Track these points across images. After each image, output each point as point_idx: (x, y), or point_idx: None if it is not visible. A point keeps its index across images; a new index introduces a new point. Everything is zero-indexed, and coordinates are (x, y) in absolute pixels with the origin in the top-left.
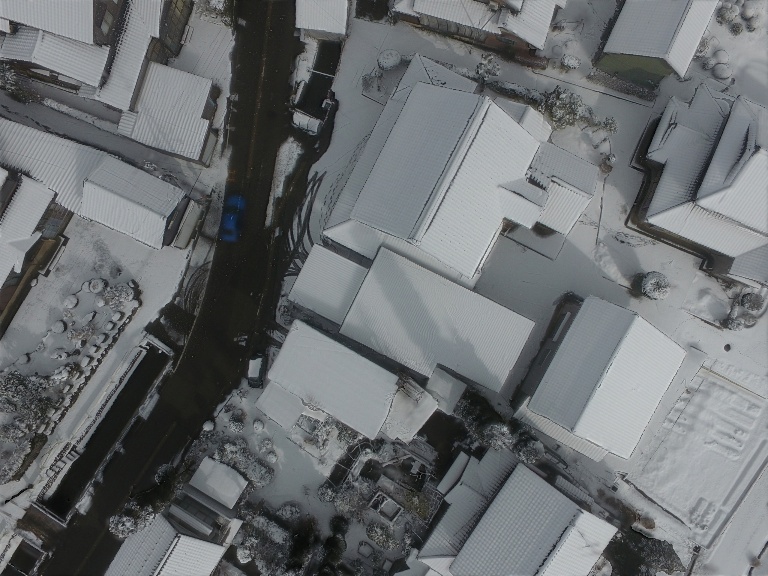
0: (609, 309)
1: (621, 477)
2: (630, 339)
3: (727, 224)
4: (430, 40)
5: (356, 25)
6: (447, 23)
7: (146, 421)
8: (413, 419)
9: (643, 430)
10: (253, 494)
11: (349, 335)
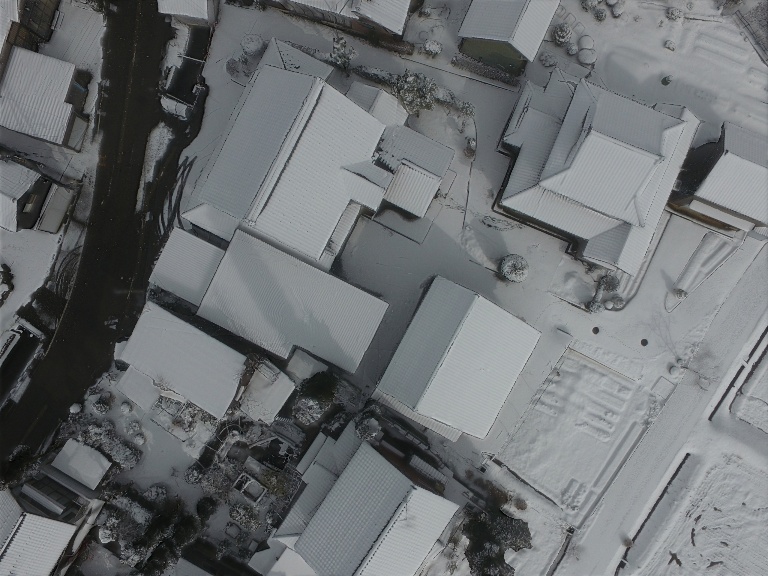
0: (454, 290)
1: (489, 458)
2: (472, 319)
3: (576, 206)
4: (299, 26)
5: (226, 11)
6: (308, 8)
7: (17, 404)
8: (273, 400)
9: (498, 410)
10: (122, 476)
11: (206, 317)
